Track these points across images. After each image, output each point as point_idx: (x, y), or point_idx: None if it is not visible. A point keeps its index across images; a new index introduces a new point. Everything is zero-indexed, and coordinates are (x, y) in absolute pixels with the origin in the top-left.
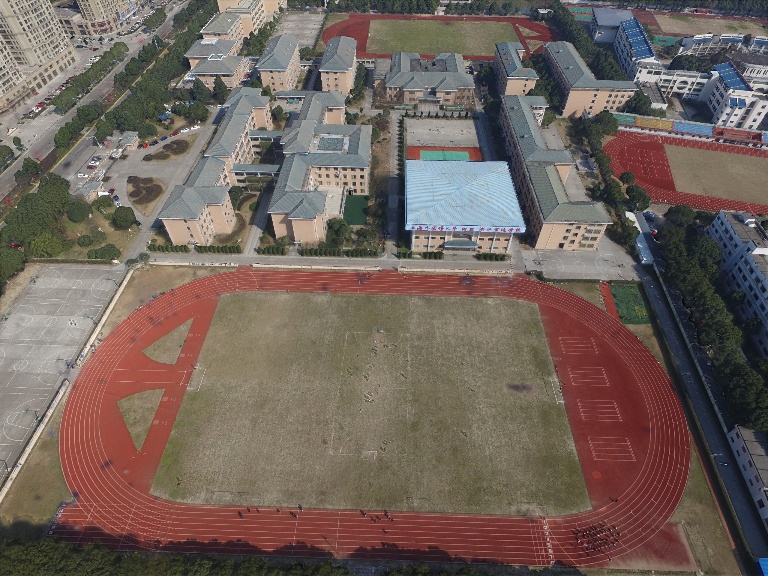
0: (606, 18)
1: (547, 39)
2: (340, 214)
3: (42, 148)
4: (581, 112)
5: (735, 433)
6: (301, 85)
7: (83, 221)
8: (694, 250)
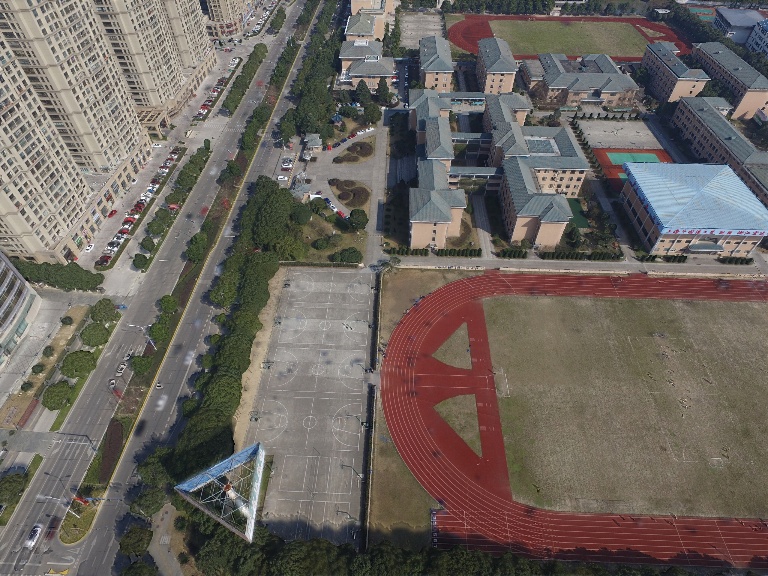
0: (737, 18)
1: (675, 40)
2: None
3: None
4: (752, 113)
5: None
6: (453, 86)
7: (306, 224)
8: None
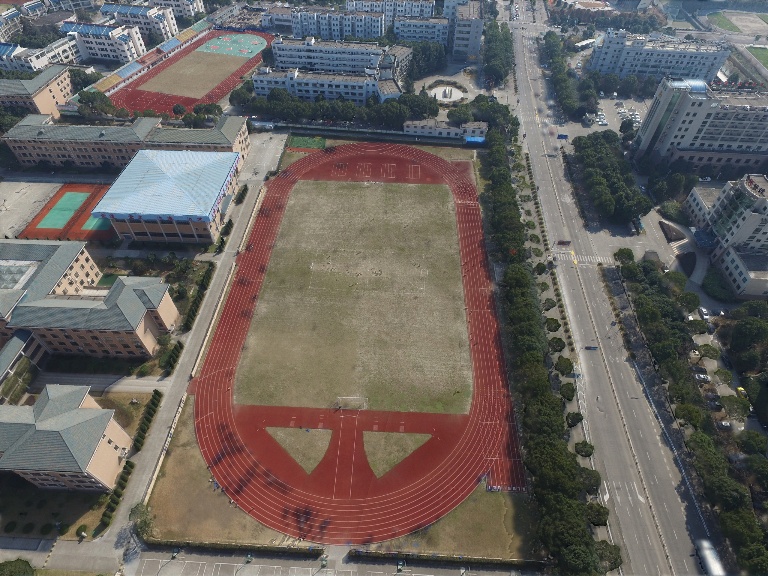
0: None
1: None
2: None
3: None
4: (55, 112)
5: (406, 128)
6: None
7: None
8: (281, 98)
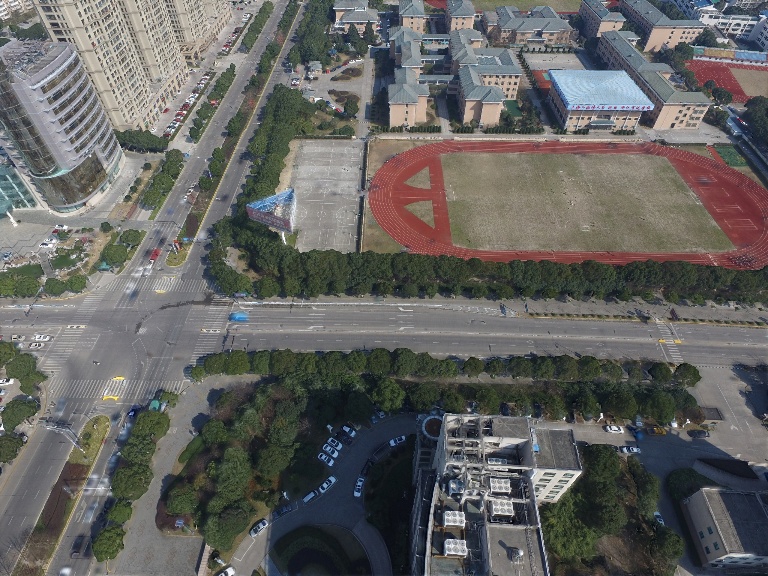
0: None
1: None
2: None
3: (247, 74)
4: (659, 47)
5: None
6: None
7: (312, 116)
8: None
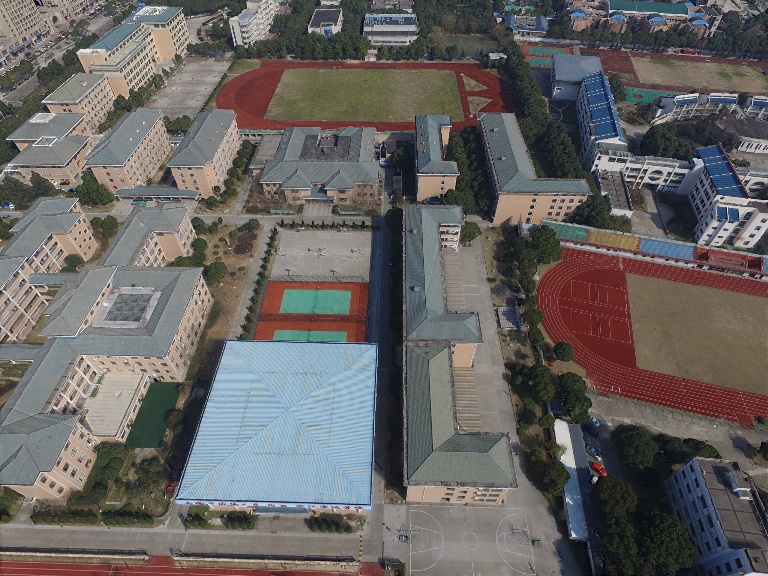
0: (567, 70)
1: (495, 95)
2: (115, 436)
3: None
4: (517, 219)
5: None
6: (162, 173)
7: None
8: (648, 547)
